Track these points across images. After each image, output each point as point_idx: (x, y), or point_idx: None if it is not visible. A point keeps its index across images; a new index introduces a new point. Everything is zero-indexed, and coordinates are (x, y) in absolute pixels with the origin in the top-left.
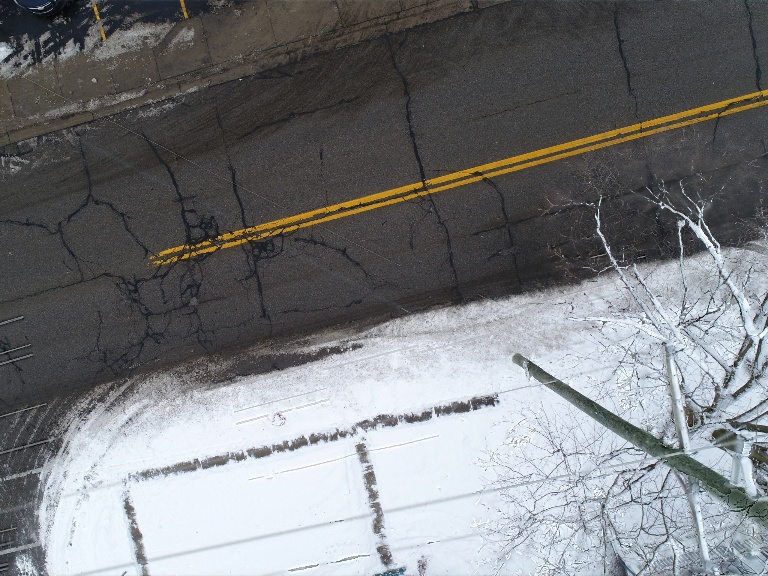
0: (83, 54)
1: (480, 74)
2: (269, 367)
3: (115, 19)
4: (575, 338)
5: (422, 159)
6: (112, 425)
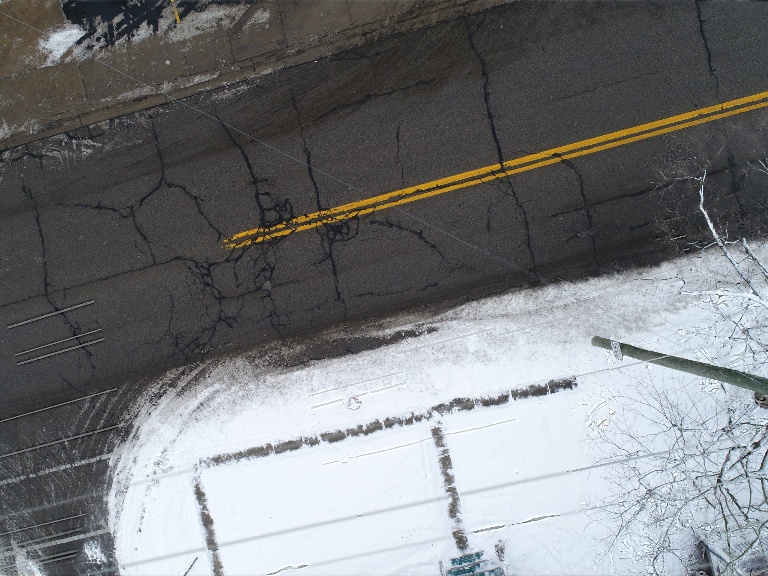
0: (157, 36)
1: (559, 55)
2: (343, 351)
3: (189, 1)
4: (655, 320)
5: (500, 141)
6: (183, 410)
